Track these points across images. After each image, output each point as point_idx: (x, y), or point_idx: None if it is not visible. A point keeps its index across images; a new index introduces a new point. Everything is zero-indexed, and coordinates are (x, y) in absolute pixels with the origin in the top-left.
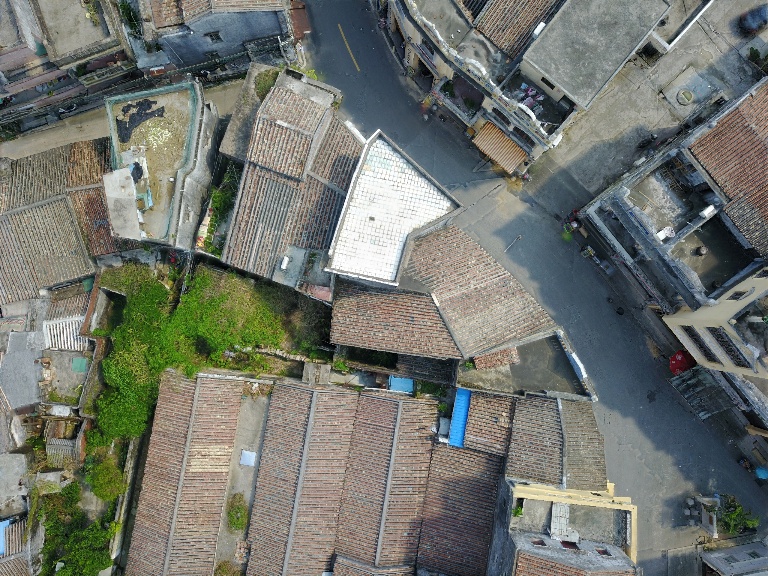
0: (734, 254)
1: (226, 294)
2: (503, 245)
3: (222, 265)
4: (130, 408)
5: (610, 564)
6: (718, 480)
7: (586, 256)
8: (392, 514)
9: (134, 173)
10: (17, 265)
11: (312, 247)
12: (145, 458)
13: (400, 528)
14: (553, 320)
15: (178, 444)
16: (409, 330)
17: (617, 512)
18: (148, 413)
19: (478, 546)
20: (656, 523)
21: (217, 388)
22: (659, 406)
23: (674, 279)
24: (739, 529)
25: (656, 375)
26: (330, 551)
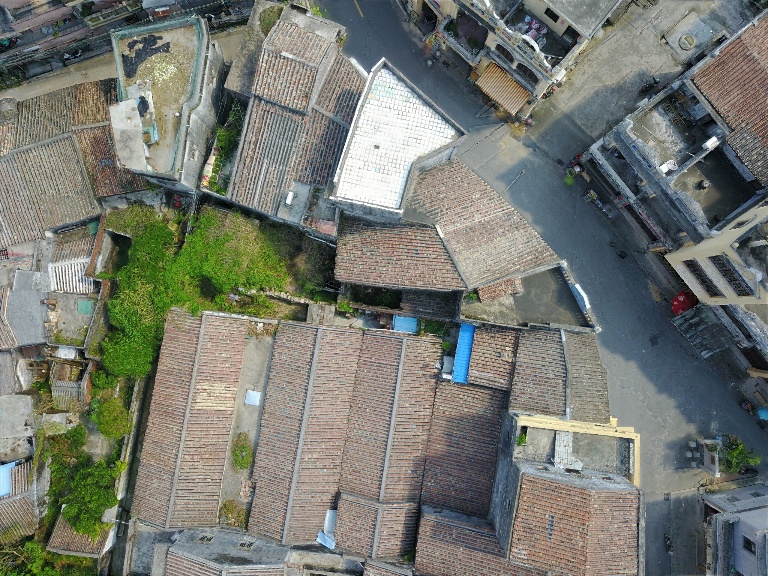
0: (736, 188)
1: (231, 234)
2: None
3: (227, 205)
4: (135, 348)
5: (613, 486)
6: (720, 423)
7: (589, 200)
8: (396, 451)
9: (140, 107)
10: (23, 205)
11: (317, 183)
12: (150, 402)
13: (404, 465)
14: None
15: (183, 382)
16: (413, 263)
17: (620, 442)
18: (153, 354)
19: (482, 481)
20: (658, 466)
21: (222, 326)
22: (661, 349)
23: (677, 213)
24: (741, 470)
25: (658, 319)
26: (334, 489)
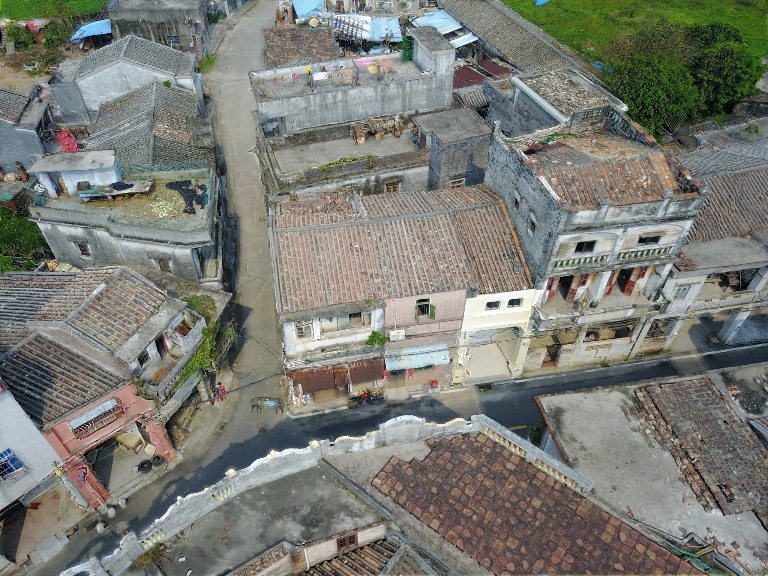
0: None
1: None
2: None
3: None
4: None
5: None
6: None
7: None
8: None
9: (121, 183)
10: None
11: None
12: None
13: None
14: None
15: None
16: None
17: None
18: None
19: None
20: None
21: None
22: None
23: None
24: None
25: None
26: None
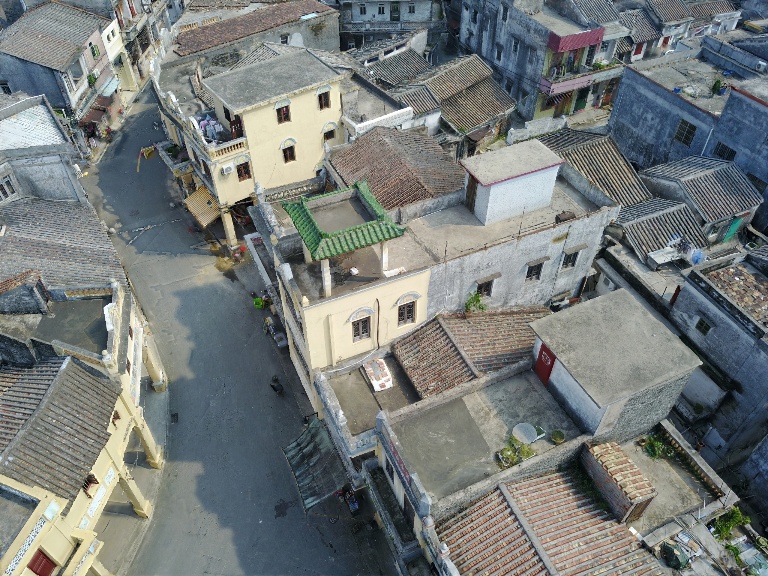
0: None
1: None
2: (183, 307)
3: None
4: None
5: None
6: None
7: (266, 330)
8: None
9: None
10: None
11: None
12: None
13: None
14: None
15: None
16: None
17: None
18: None
19: None
20: None
21: None
22: (287, 525)
23: None
24: None
25: None
26: None
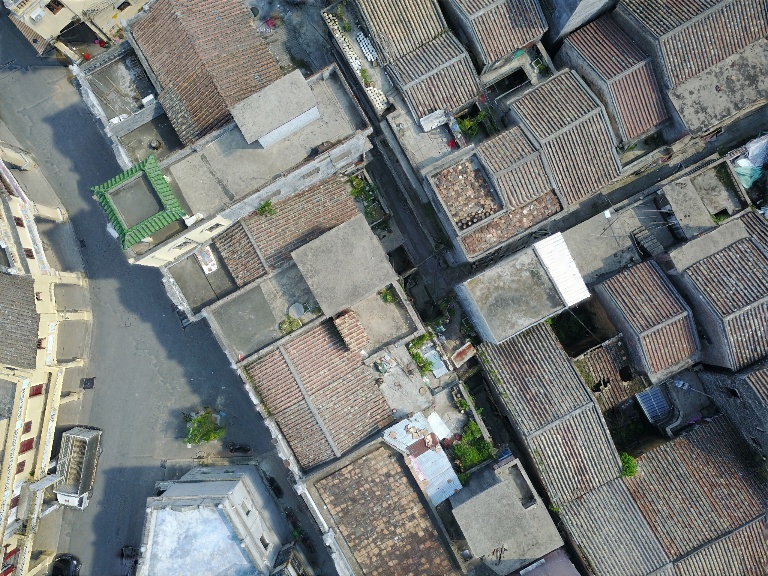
0: None
1: None
2: (54, 134)
3: None
4: None
5: None
6: (226, 398)
7: None
8: None
9: None
10: None
11: None
12: None
13: None
14: (8, 193)
15: None
16: None
17: None
18: None
19: None
20: (160, 432)
21: None
22: None
23: None
24: (230, 447)
25: None
26: None
